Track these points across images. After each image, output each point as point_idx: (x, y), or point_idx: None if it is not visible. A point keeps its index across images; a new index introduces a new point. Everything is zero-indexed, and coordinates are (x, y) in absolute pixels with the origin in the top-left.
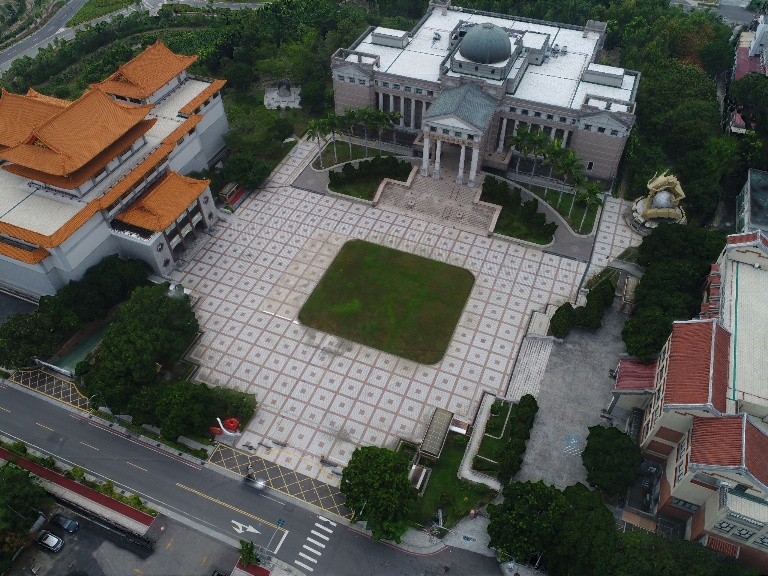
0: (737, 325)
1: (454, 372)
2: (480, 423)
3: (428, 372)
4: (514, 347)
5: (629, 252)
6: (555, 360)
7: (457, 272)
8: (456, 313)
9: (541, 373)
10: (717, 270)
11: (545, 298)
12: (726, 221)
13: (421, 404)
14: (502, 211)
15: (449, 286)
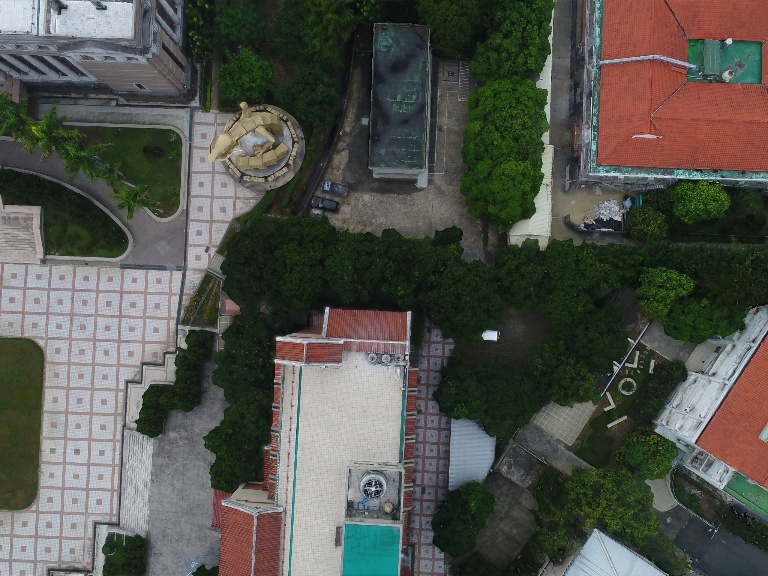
0: (296, 484)
1: (55, 509)
2: (98, 568)
3: (26, 520)
4: (115, 448)
5: (233, 232)
6: (159, 462)
7: (17, 349)
8: (34, 420)
9: (147, 486)
10: (280, 376)
11: (137, 355)
12: (362, 115)
13: (31, 564)
14: (45, 211)
15: (13, 378)
